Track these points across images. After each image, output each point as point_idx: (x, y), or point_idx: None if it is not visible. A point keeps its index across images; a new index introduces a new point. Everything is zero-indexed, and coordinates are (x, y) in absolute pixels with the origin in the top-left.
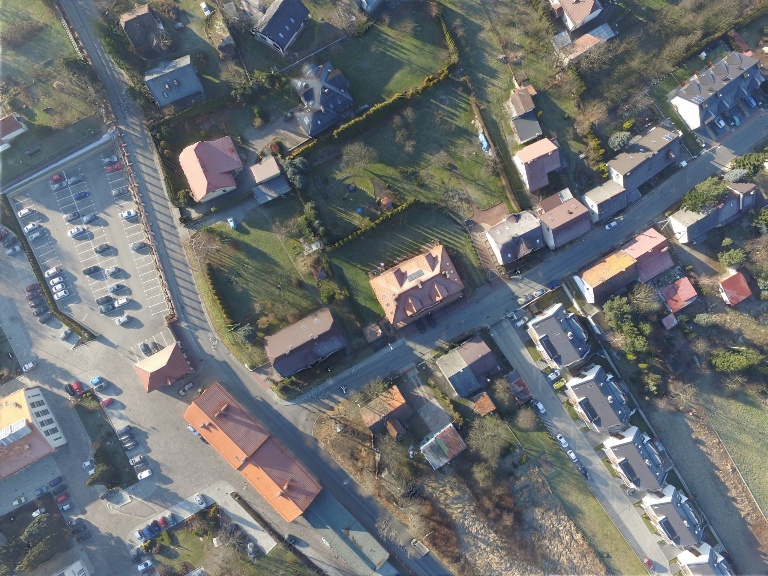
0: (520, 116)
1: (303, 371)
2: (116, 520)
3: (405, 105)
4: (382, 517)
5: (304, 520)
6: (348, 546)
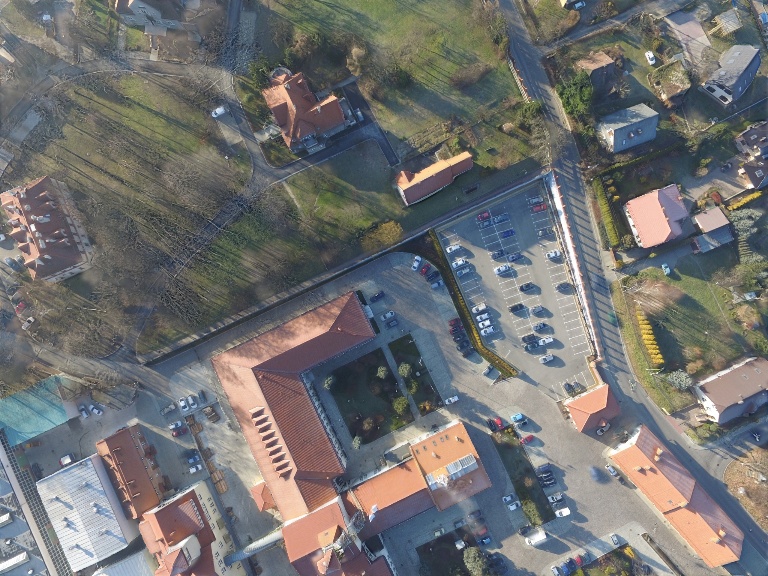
0: None
1: None
2: (531, 556)
3: None
4: None
5: None
6: None
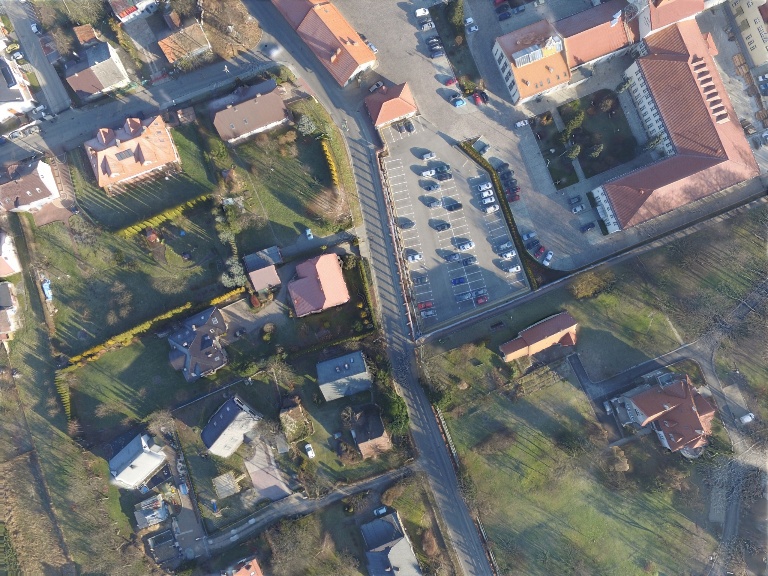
0: (4, 309)
1: None
2: None
3: (115, 328)
4: None
5: None
6: None
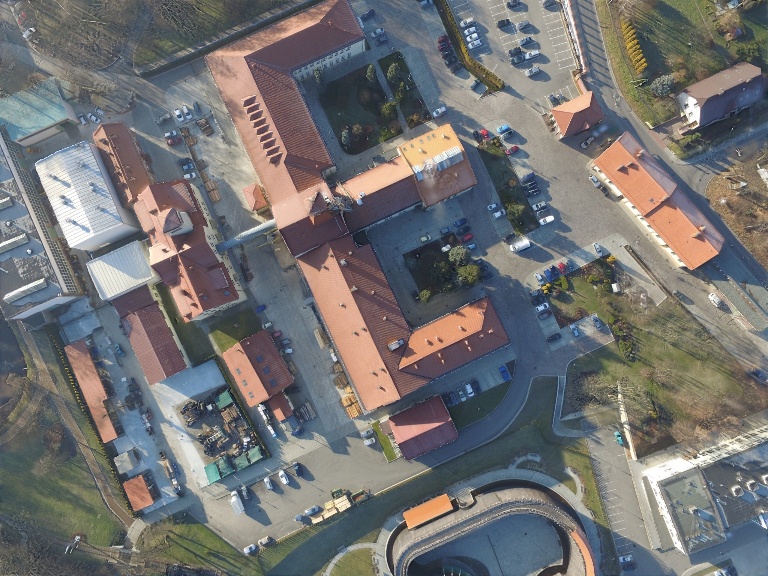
0: None
1: (707, 128)
2: (515, 263)
3: None
4: (764, 281)
5: (690, 279)
6: (748, 296)
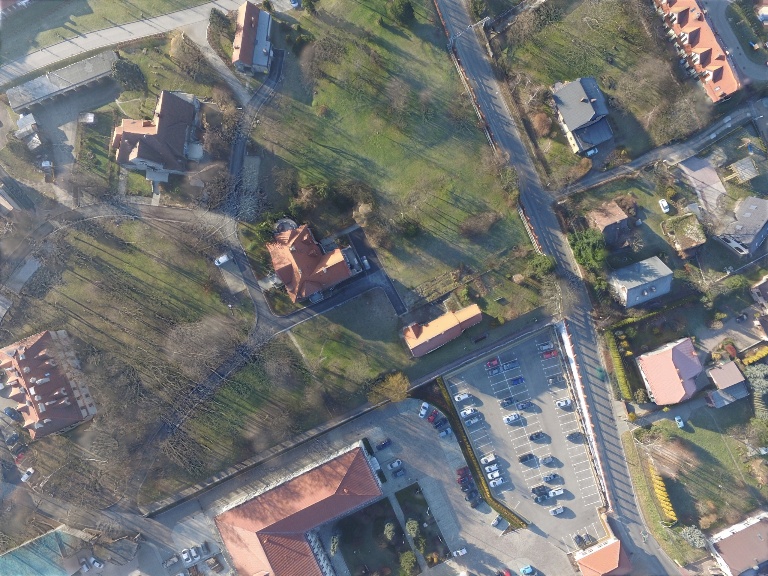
0: None
1: None
2: None
3: None
4: None
5: None
6: None
